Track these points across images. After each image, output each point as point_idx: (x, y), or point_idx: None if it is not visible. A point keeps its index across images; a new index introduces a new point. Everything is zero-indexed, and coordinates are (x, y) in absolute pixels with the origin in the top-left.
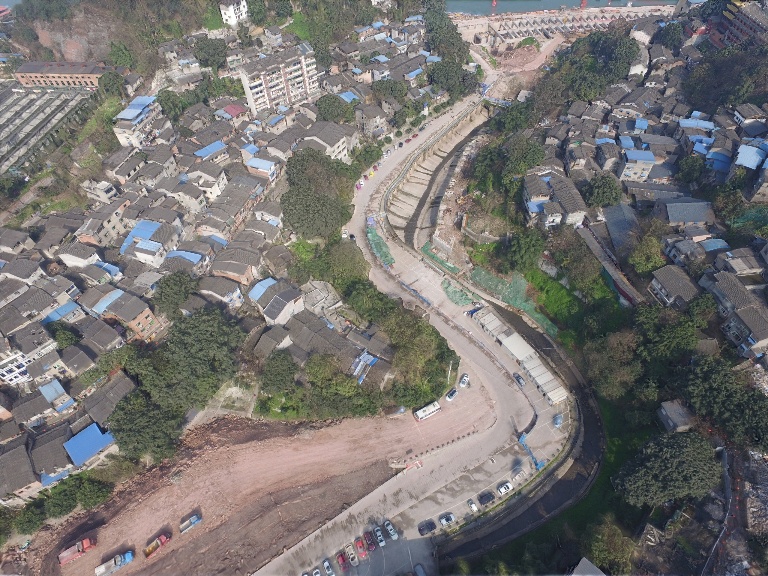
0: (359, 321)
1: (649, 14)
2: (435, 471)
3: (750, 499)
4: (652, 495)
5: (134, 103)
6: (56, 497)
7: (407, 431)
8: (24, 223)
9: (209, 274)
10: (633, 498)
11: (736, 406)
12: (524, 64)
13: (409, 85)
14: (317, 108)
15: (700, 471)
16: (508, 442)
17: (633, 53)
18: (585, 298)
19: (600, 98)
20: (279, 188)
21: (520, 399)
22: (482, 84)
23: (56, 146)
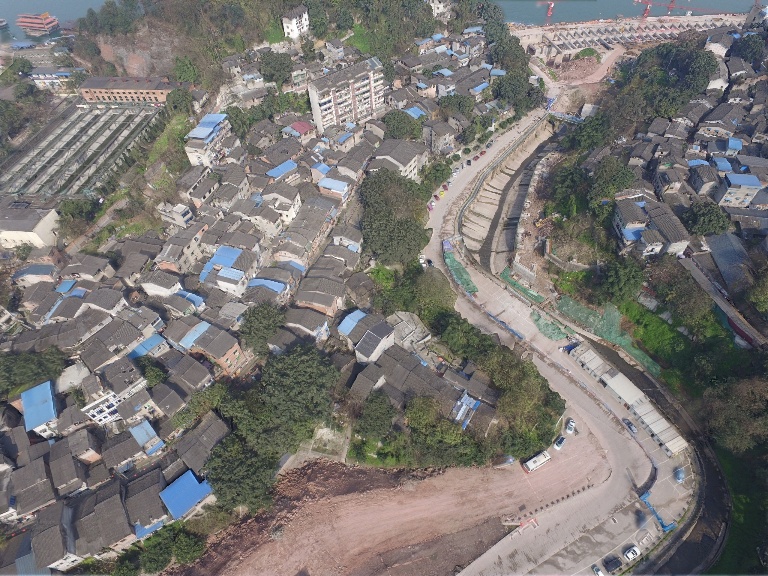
0: (451, 357)
1: (711, 23)
2: (551, 530)
3: None
4: None
5: (204, 121)
6: (151, 551)
7: (517, 483)
8: (100, 247)
9: (289, 303)
10: None
11: None
12: (585, 76)
13: (474, 100)
14: (385, 125)
15: None
16: (628, 499)
17: (713, 67)
18: (693, 335)
19: (682, 115)
20: (351, 209)
21: (634, 449)
22: (548, 98)
23: (128, 166)
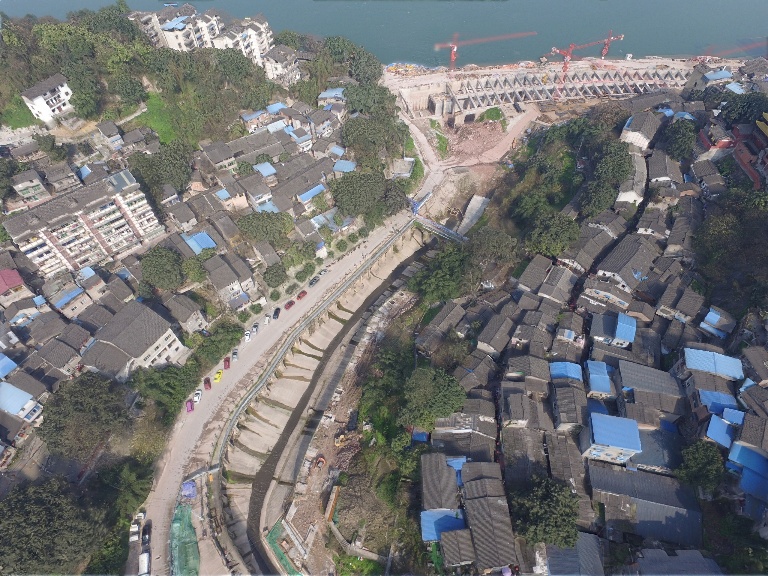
0: None
1: (653, 72)
2: None
3: None
4: None
5: None
6: None
7: None
8: None
9: None
10: None
11: None
12: (483, 151)
13: (302, 210)
14: None
15: None
16: None
17: (623, 173)
18: None
19: (569, 255)
20: None
21: None
22: (412, 201)
23: None
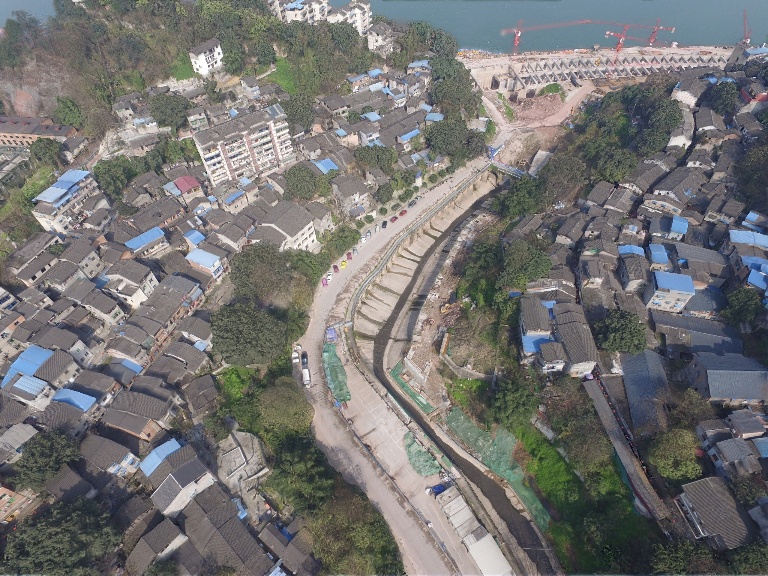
0: (284, 501)
1: (697, 57)
2: None
3: None
4: None
5: (62, 179)
6: None
7: None
8: None
9: None
10: None
11: None
12: (545, 117)
13: (402, 149)
14: (286, 181)
15: None
16: None
17: (674, 121)
18: None
19: (629, 180)
20: (226, 285)
21: None
22: (490, 147)
23: None
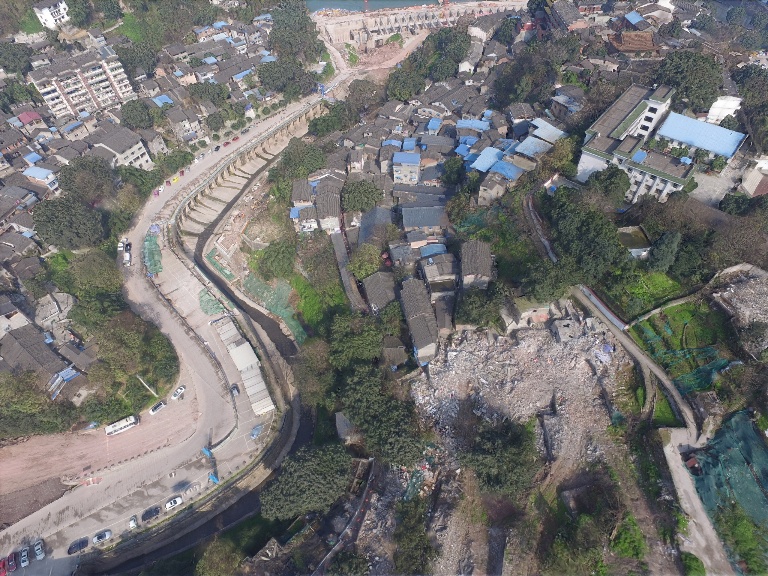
0: (88, 334)
1: None
2: (111, 487)
3: (369, 511)
4: (274, 510)
5: None
6: None
7: (94, 447)
8: None
9: None
10: (263, 513)
11: (372, 417)
12: (383, 61)
13: (237, 87)
14: None
15: (315, 485)
16: (197, 455)
17: (460, 50)
18: None
19: (415, 97)
20: None
21: (227, 410)
22: (319, 84)
23: None
